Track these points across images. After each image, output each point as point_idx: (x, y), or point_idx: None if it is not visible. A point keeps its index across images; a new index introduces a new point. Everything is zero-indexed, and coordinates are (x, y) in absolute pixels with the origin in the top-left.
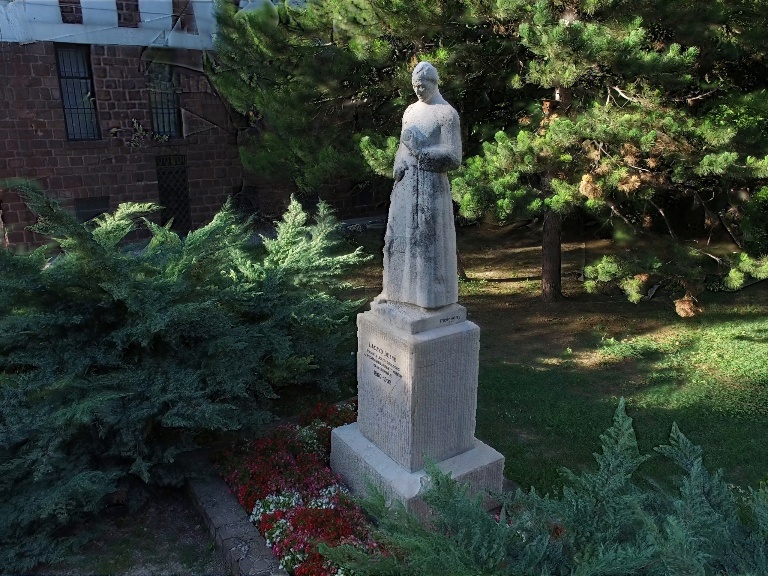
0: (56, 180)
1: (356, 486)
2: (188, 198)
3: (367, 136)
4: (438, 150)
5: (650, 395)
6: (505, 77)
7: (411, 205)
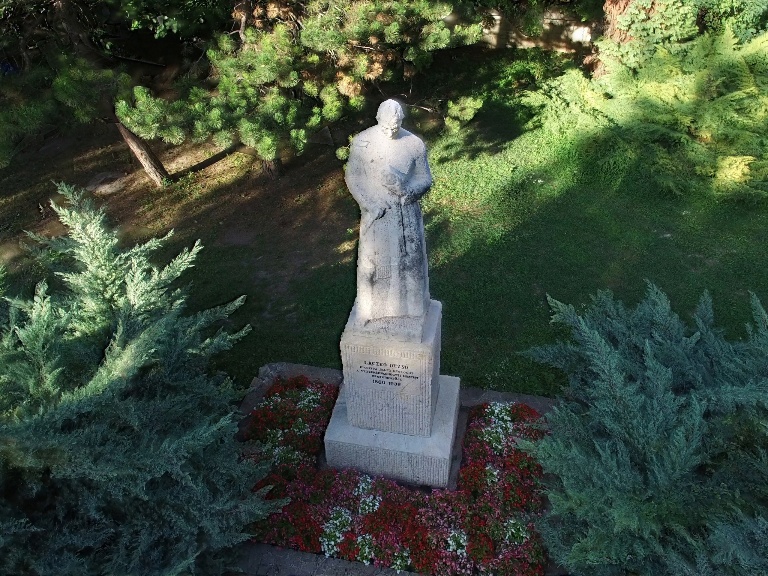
0: None
1: (374, 469)
2: None
3: (122, 101)
4: (420, 184)
5: (439, 248)
6: None
7: (397, 239)
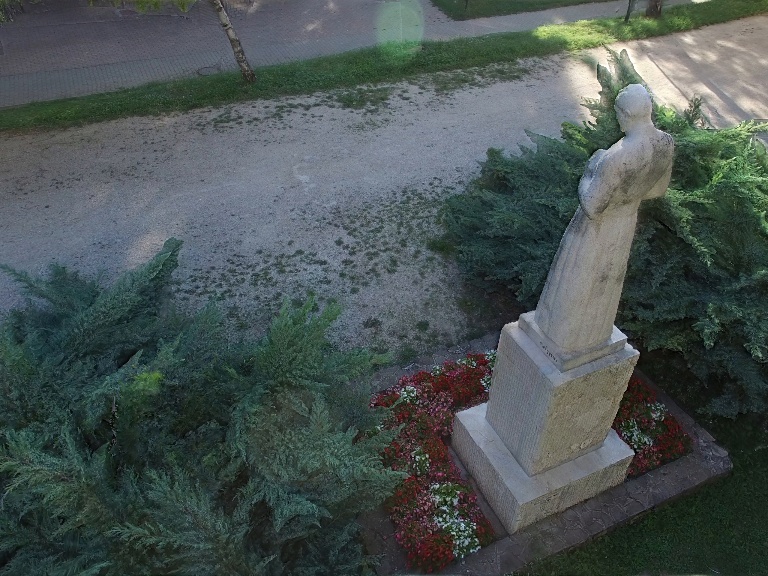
0: None
1: None
2: None
3: None
4: (582, 186)
5: None
6: None
7: None
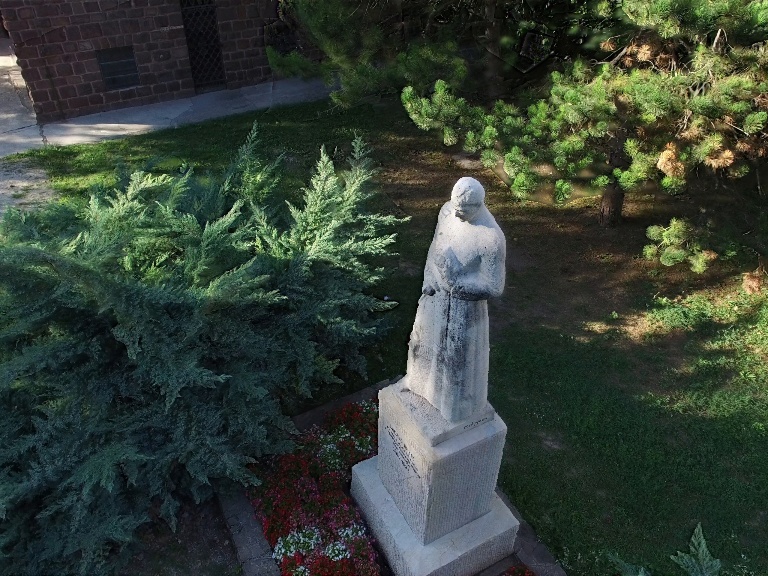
0: (73, 30)
1: (373, 528)
2: (219, 43)
3: (410, 87)
4: (475, 284)
5: (690, 393)
6: None
7: (440, 326)
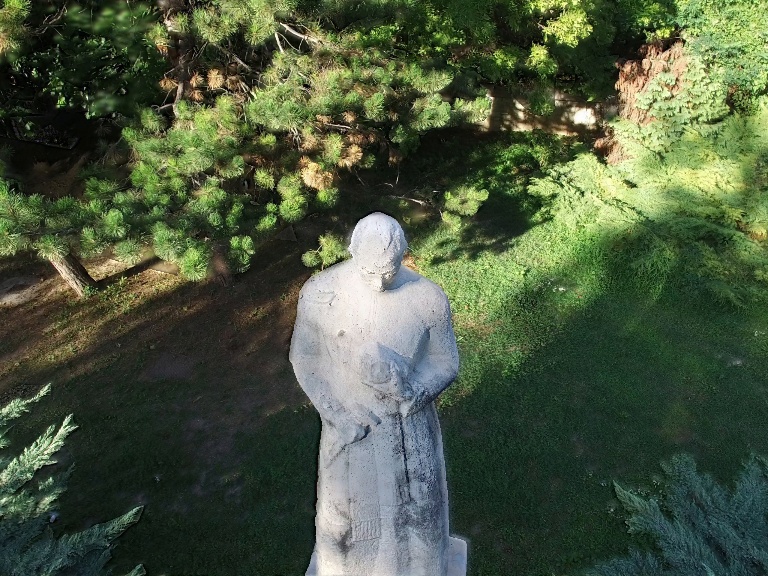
0: None
1: None
2: None
3: None
4: (438, 375)
5: None
6: (100, 10)
7: (392, 475)
